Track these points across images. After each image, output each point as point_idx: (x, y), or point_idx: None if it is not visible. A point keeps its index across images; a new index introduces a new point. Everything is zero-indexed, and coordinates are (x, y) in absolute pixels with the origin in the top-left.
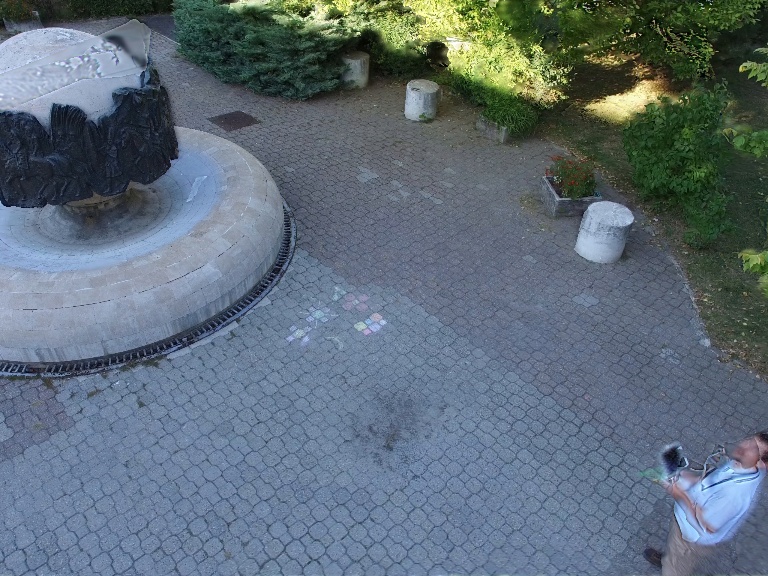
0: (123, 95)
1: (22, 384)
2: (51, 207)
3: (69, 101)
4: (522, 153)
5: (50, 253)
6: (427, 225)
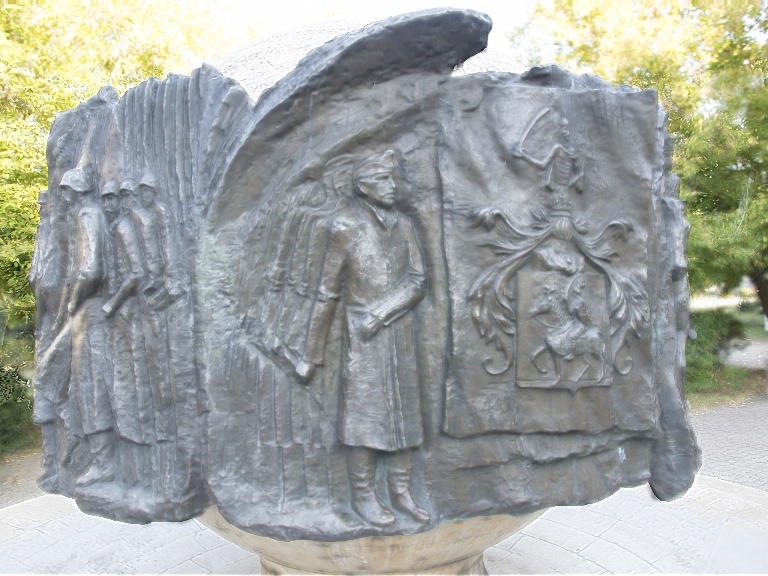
0: None
1: None
2: None
3: None
4: None
5: None
6: None
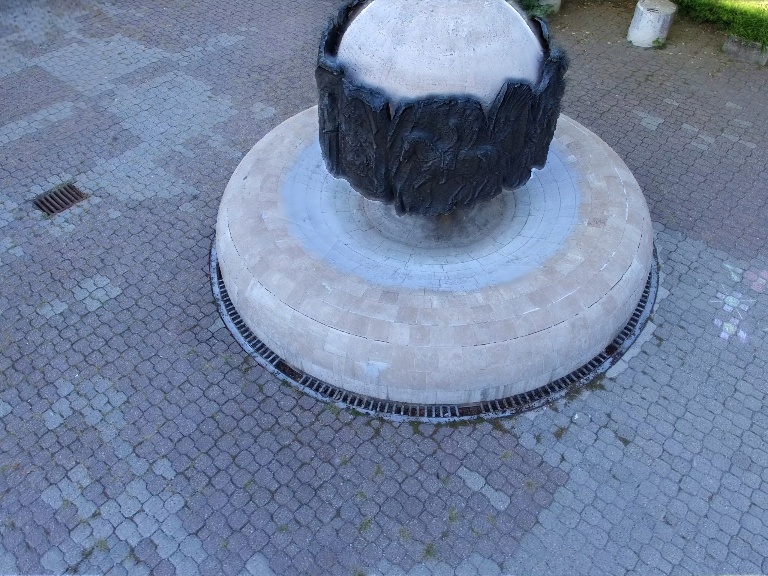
0: (559, 62)
1: (470, 431)
2: (373, 202)
3: (503, 77)
4: None
5: (425, 264)
6: (764, 176)
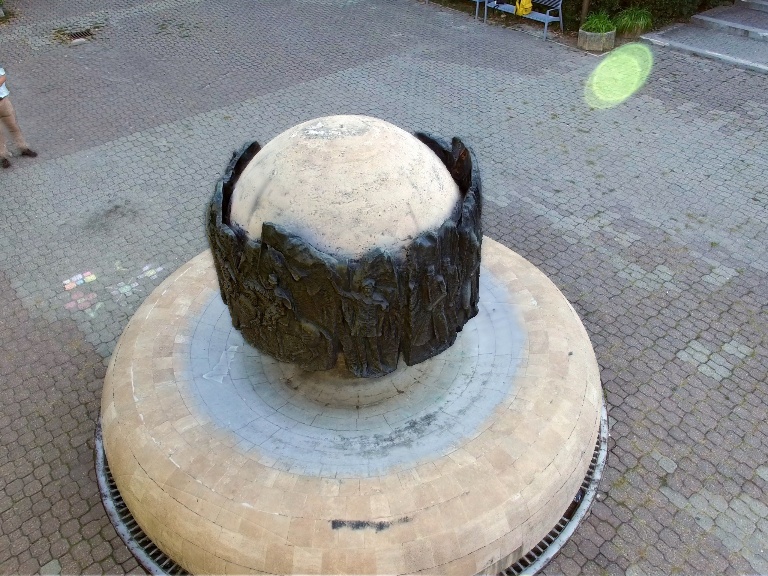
0: None
1: None
2: None
3: None
4: None
5: None
6: None
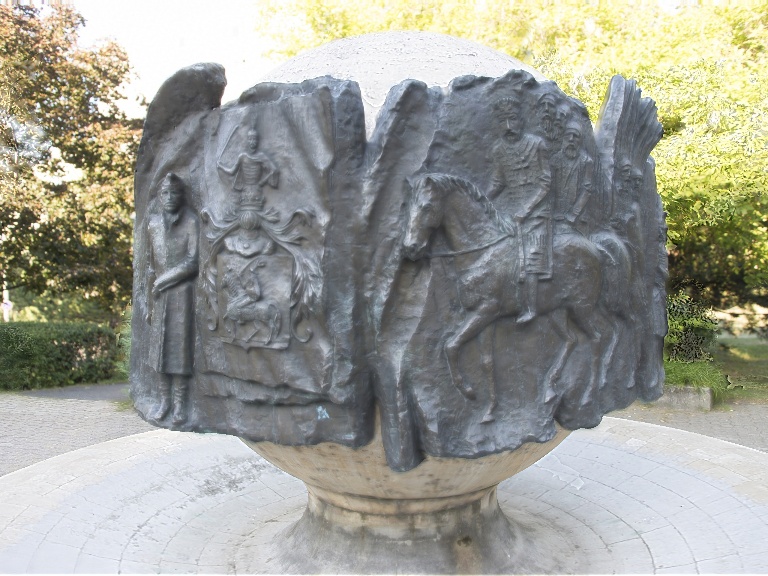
0: None
1: None
2: (263, 570)
3: None
4: (752, 414)
5: None
6: None
